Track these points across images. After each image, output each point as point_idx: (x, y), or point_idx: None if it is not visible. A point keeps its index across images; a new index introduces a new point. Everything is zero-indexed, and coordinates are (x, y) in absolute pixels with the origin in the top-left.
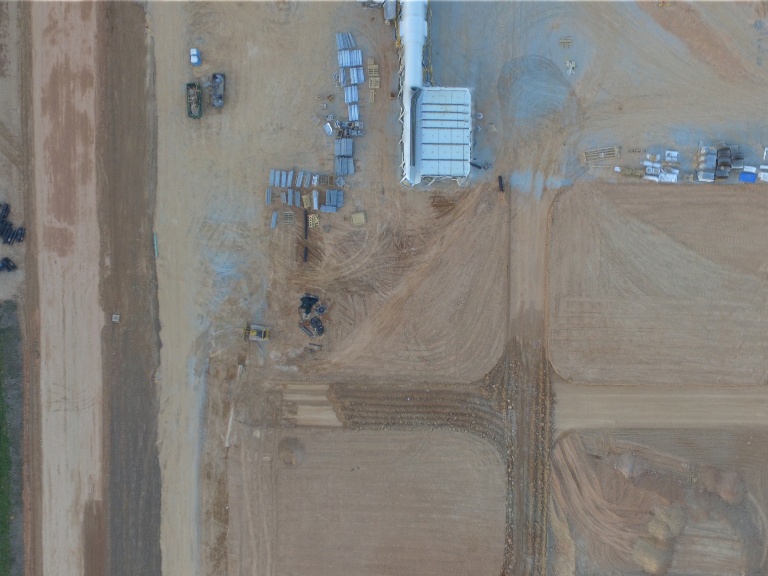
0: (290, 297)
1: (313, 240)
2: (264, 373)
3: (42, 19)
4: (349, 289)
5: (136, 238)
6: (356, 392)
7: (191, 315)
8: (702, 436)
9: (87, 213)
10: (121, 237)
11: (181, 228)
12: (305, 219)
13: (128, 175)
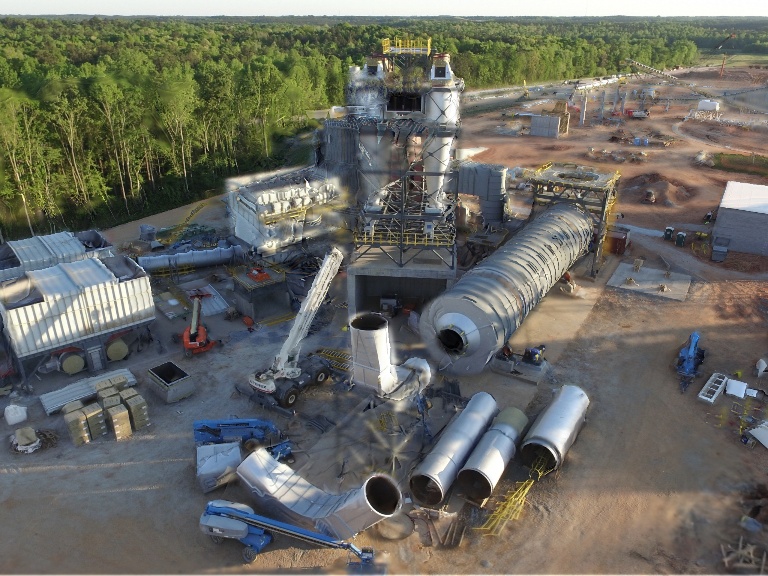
0: None
1: None
2: None
3: None
4: None
5: None
6: None
7: None
8: None
9: None
10: None
11: None
12: None
13: None
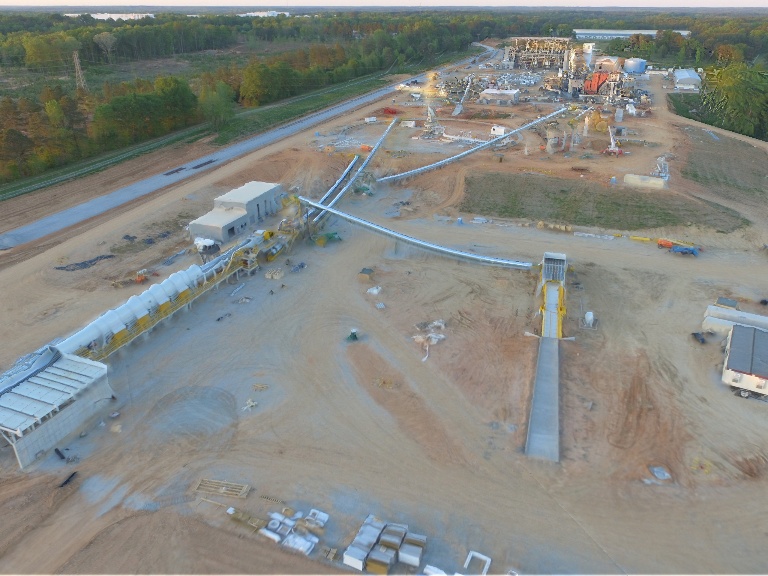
0: None
1: None
2: None
3: None
4: None
5: None
6: None
7: None
8: None
9: None
10: None
11: None
12: None
13: None
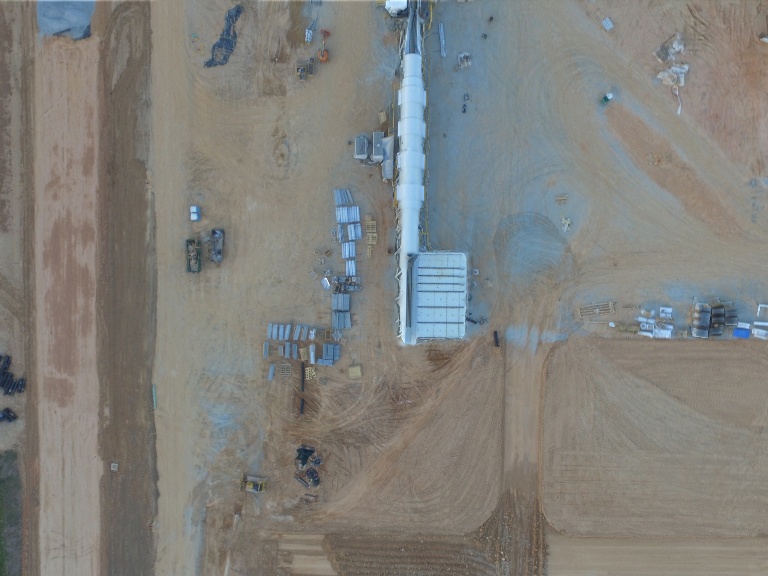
0: (286, 448)
1: (310, 392)
2: (260, 523)
3: (45, 174)
4: (345, 441)
5: (135, 389)
6: (351, 542)
7: (188, 466)
8: None
9: (87, 364)
10: (120, 388)
11: (179, 380)
12: (302, 372)
13: (128, 327)
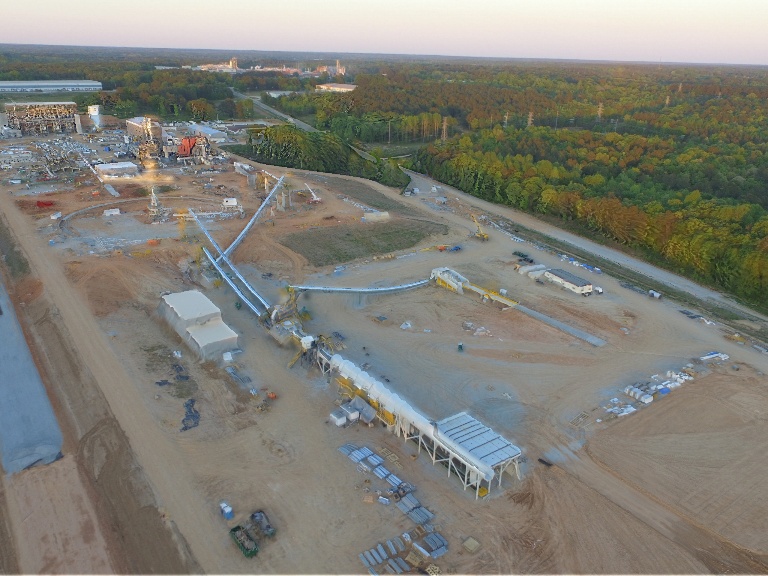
0: None
1: None
2: None
3: (35, 564)
4: None
5: None
6: None
7: None
8: None
9: None
10: None
11: None
12: (425, 575)
13: None
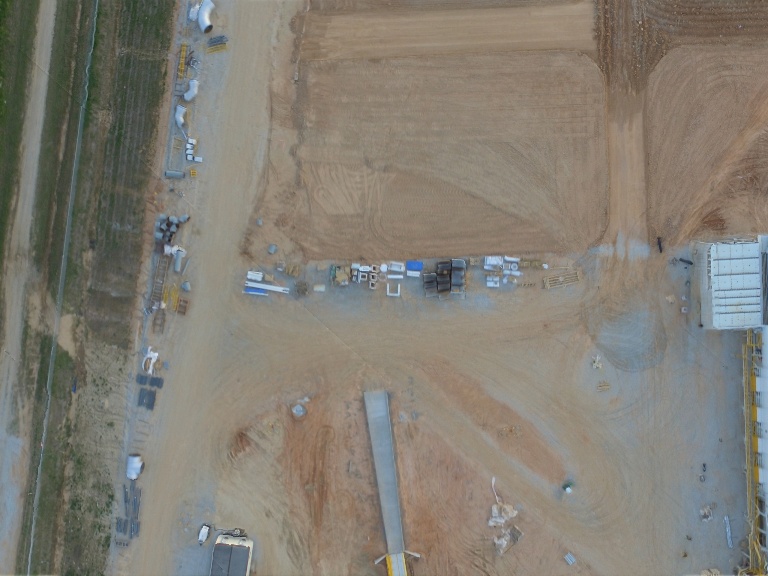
0: None
1: None
2: None
3: None
4: None
5: None
6: None
7: None
8: (442, 3)
9: None
10: None
11: None
12: None
13: None
